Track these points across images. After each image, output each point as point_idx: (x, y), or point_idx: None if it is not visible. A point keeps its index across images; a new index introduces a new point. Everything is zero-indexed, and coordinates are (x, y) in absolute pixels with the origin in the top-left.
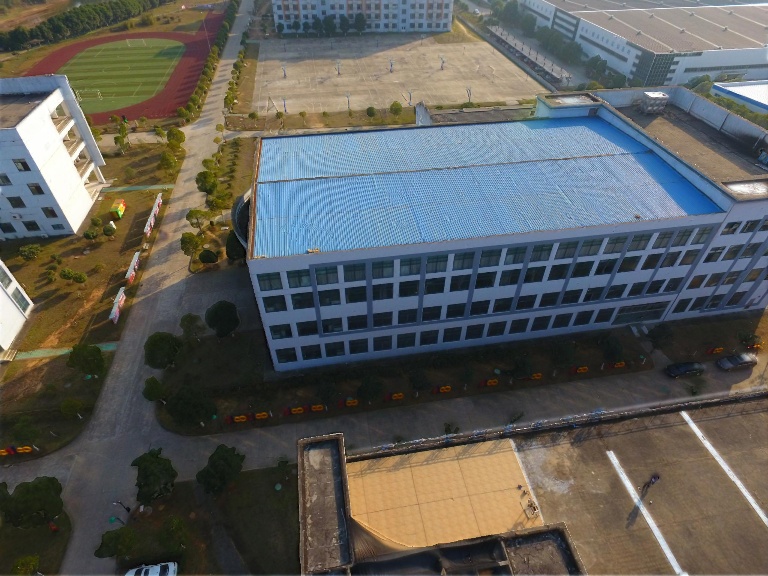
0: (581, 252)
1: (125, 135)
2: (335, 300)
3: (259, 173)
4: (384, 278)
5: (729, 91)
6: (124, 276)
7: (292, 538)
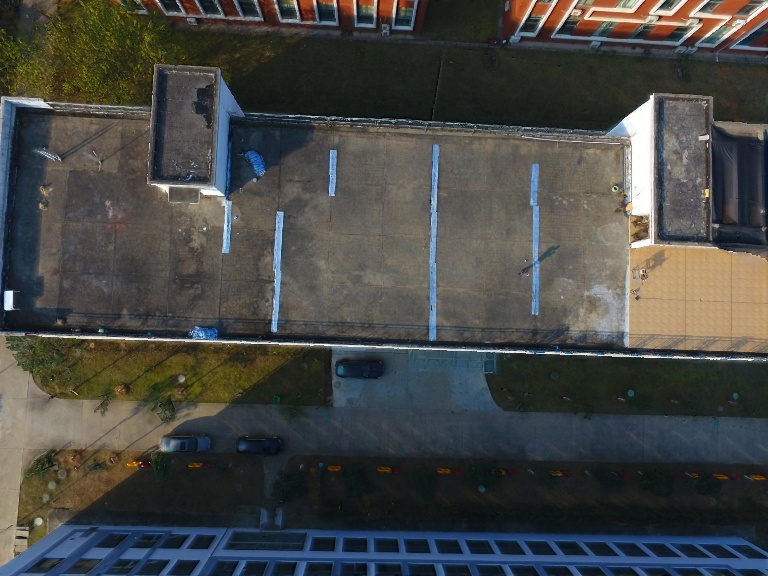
0: None
1: None
2: None
3: None
4: None
5: None
6: None
7: None
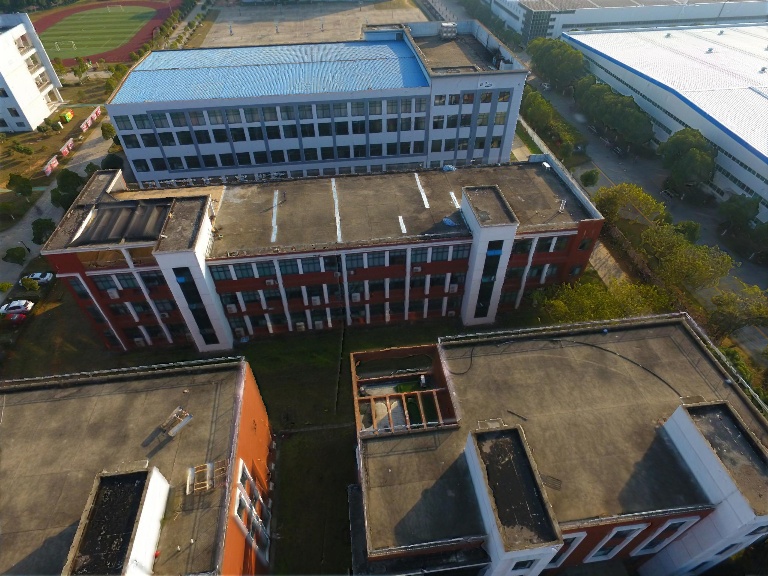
0: (336, 114)
1: (84, 70)
2: (172, 142)
3: (137, 67)
4: (200, 125)
5: (570, 37)
6: (61, 153)
7: None
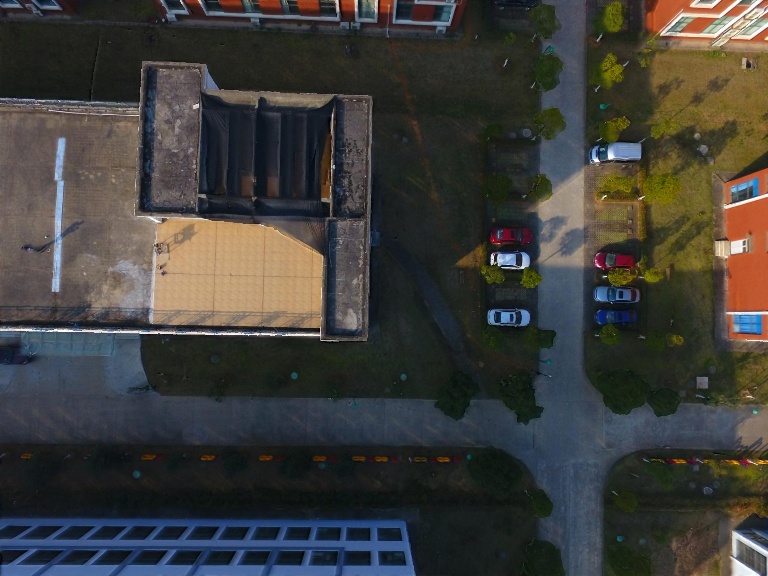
0: None
1: None
2: None
3: None
4: None
5: None
6: None
7: (392, 328)
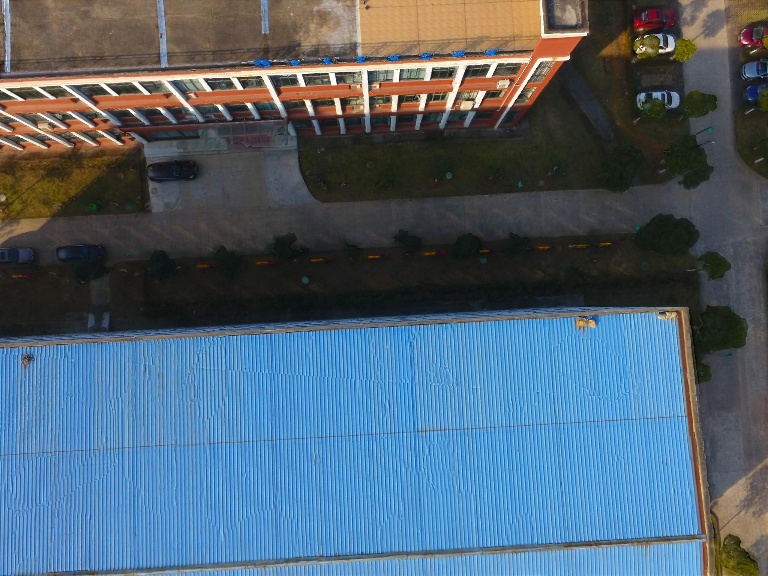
0: None
1: None
2: None
3: None
4: None
5: None
6: None
7: (541, 122)
